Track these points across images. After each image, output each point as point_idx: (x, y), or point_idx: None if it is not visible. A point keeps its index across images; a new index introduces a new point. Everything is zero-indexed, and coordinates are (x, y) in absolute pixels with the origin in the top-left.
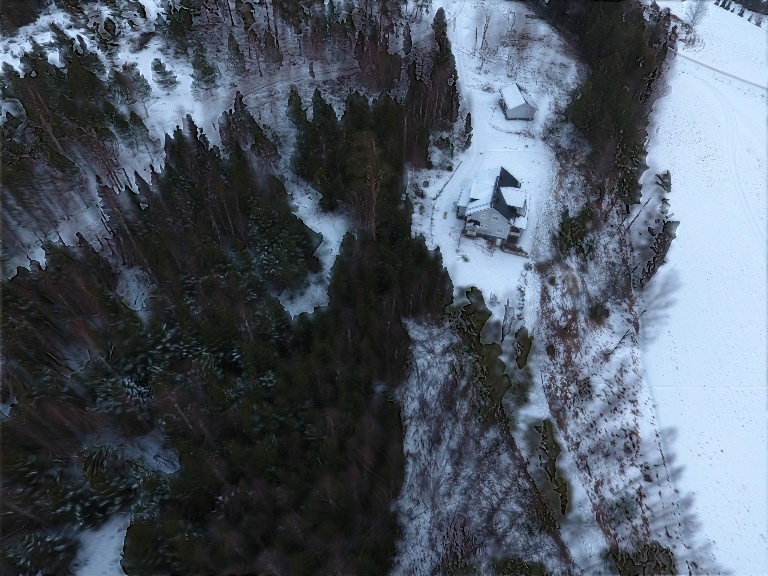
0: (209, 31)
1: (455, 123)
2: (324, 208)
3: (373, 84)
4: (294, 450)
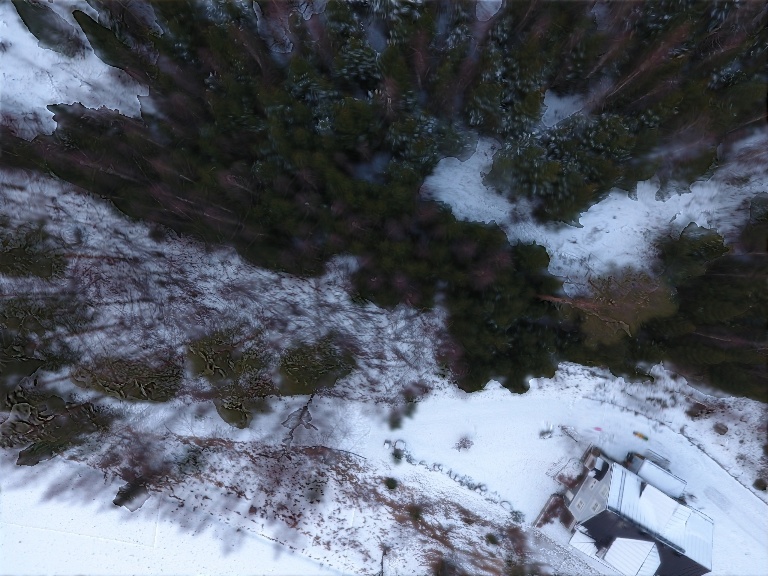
0: None
1: None
2: None
3: None
4: (241, 148)
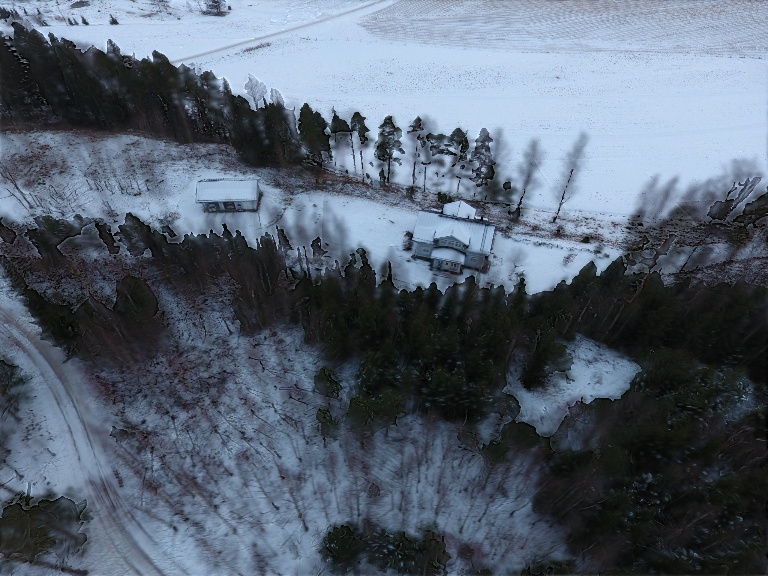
0: None
1: None
2: (539, 385)
3: (141, 346)
4: None
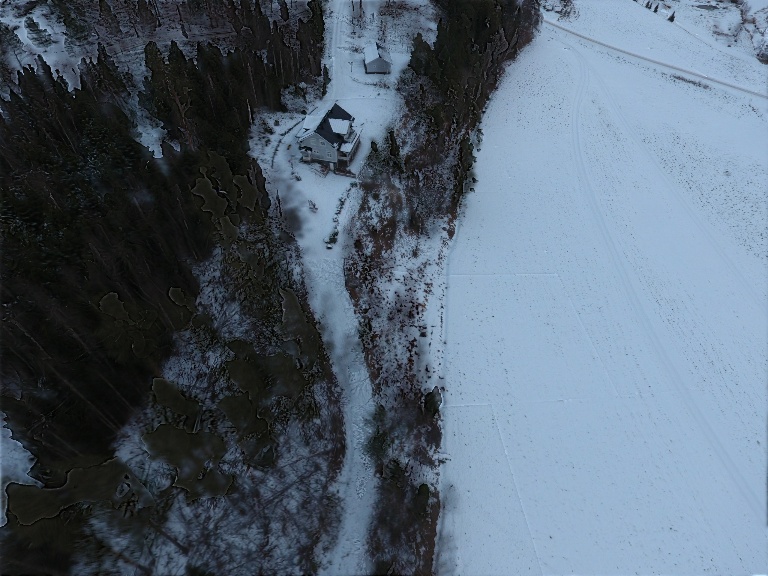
0: (95, 0)
1: (319, 77)
2: (170, 137)
3: None
4: (73, 277)
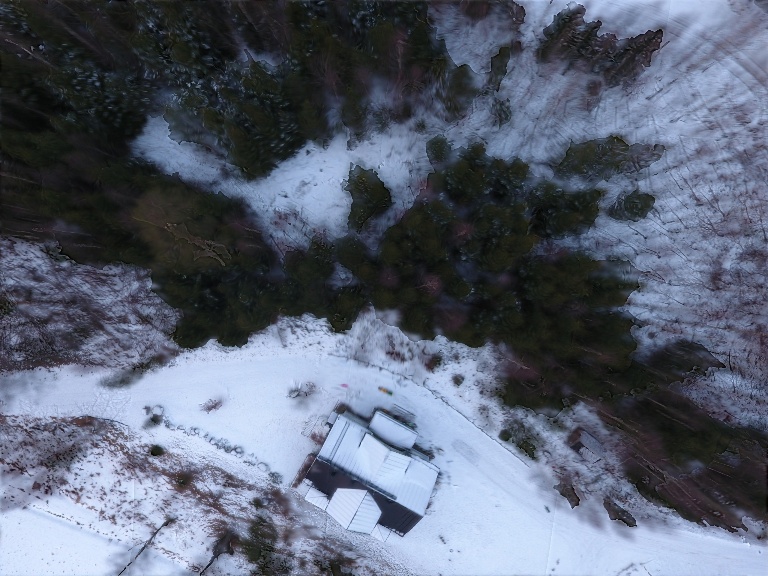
0: None
1: None
2: None
3: None
4: None
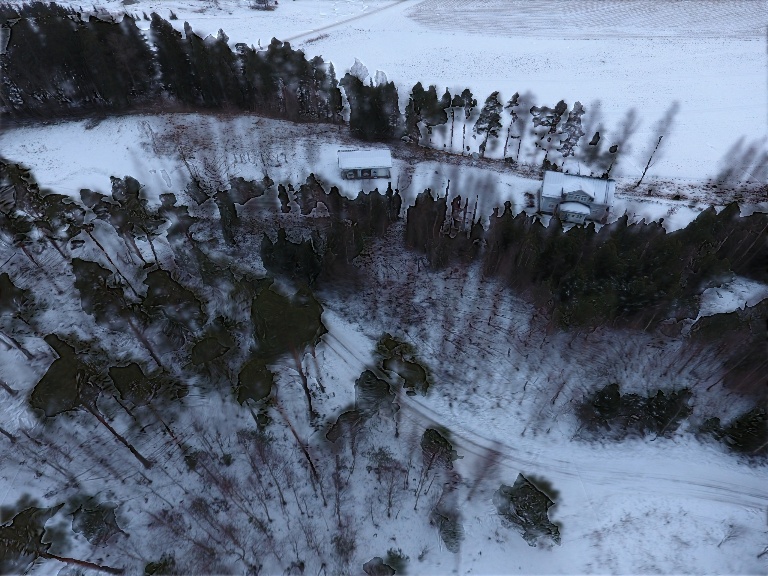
0: None
1: None
2: None
3: (347, 282)
4: None
